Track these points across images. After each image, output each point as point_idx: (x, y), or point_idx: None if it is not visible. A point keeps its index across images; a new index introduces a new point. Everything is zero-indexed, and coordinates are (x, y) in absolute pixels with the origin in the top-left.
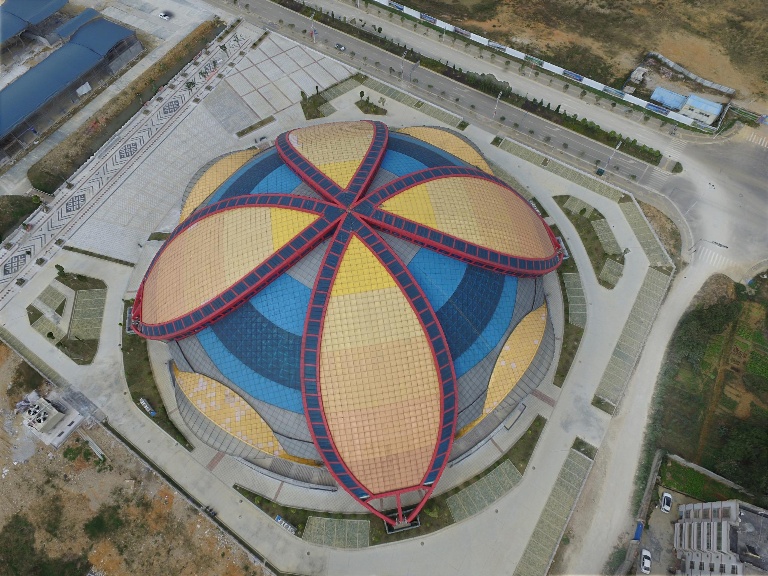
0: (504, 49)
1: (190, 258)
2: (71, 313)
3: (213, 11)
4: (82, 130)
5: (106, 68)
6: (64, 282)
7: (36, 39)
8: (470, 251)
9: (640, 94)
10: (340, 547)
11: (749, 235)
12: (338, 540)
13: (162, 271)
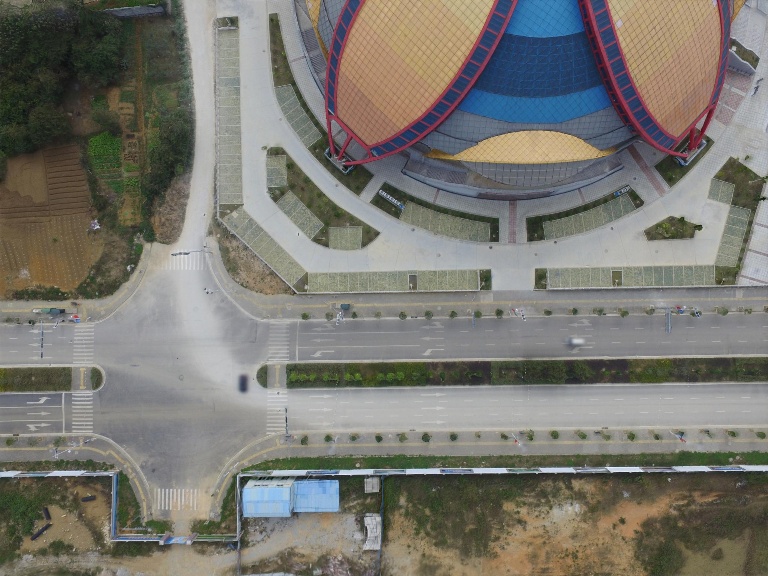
0: (578, 470)
1: None
2: None
3: None
4: None
5: None
6: None
7: None
8: None
9: (355, 489)
10: None
11: (158, 319)
12: None
13: None
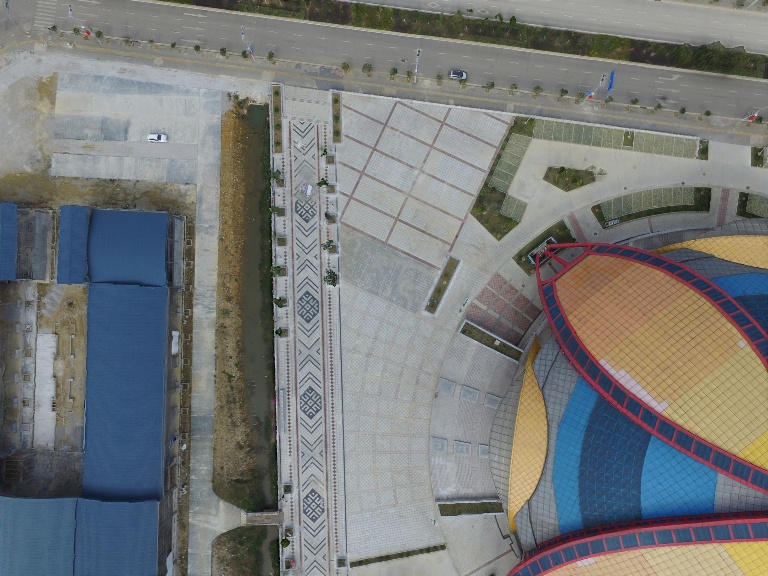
0: None
1: None
2: None
3: (217, 86)
4: (223, 400)
5: (173, 292)
6: None
7: (14, 282)
8: None
9: None
10: None
11: None
12: None
13: None
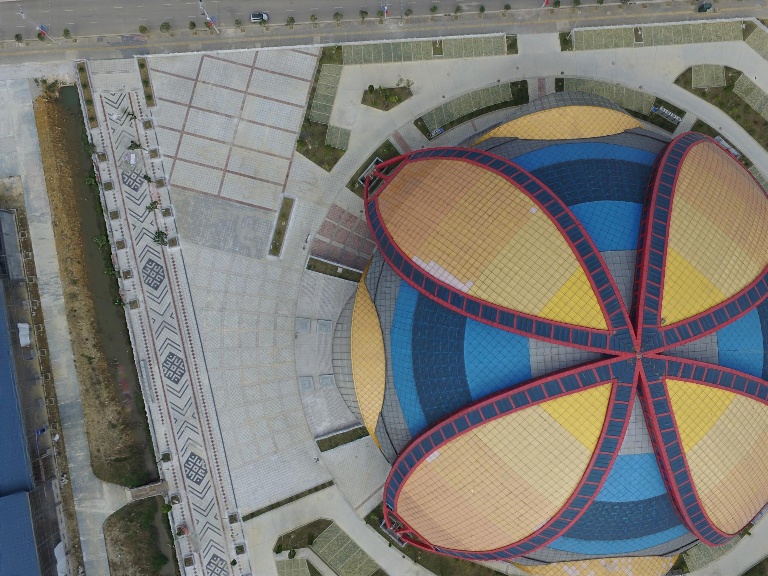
0: None
1: (473, 494)
2: (328, 567)
3: (23, 74)
4: (87, 383)
5: (12, 285)
6: (287, 548)
7: None
8: (762, 291)
9: None
10: (721, 556)
11: None
12: (716, 553)
13: (430, 508)
